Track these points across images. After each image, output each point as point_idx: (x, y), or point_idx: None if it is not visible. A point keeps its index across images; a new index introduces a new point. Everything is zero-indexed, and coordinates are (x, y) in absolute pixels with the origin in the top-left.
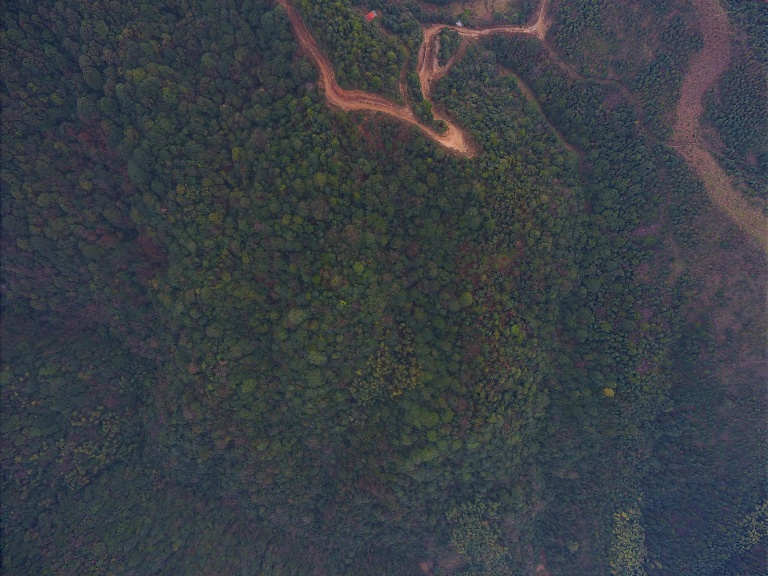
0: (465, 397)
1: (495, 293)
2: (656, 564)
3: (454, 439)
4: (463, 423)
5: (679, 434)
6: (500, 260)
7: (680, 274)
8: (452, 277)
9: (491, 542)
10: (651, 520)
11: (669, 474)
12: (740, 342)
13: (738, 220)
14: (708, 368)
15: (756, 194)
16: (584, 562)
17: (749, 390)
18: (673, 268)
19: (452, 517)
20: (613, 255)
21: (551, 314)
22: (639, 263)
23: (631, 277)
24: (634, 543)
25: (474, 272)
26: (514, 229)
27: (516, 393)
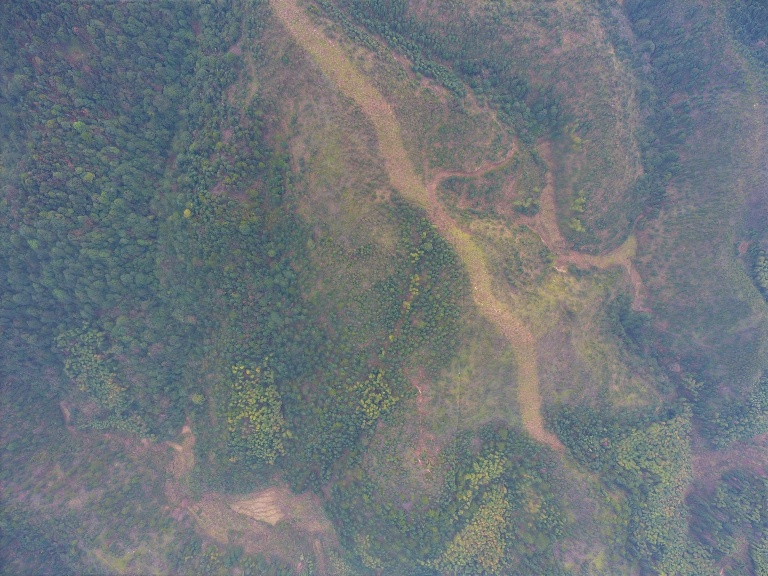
0: (16, 185)
1: (59, 84)
2: (286, 433)
3: (12, 233)
4: (12, 212)
5: (285, 283)
6: (73, 53)
7: (254, 93)
8: (14, 60)
9: (108, 380)
10: (287, 387)
11: (286, 330)
12: (307, 171)
13: (296, 35)
14: (289, 202)
15: (323, 14)
16: (212, 420)
17: (327, 229)
18: (250, 88)
19: (65, 346)
20: (208, 75)
21: (149, 132)
22: (228, 84)
23: (221, 98)
24: (265, 407)
25: (26, 52)
26: (62, 9)
27: (92, 201)
